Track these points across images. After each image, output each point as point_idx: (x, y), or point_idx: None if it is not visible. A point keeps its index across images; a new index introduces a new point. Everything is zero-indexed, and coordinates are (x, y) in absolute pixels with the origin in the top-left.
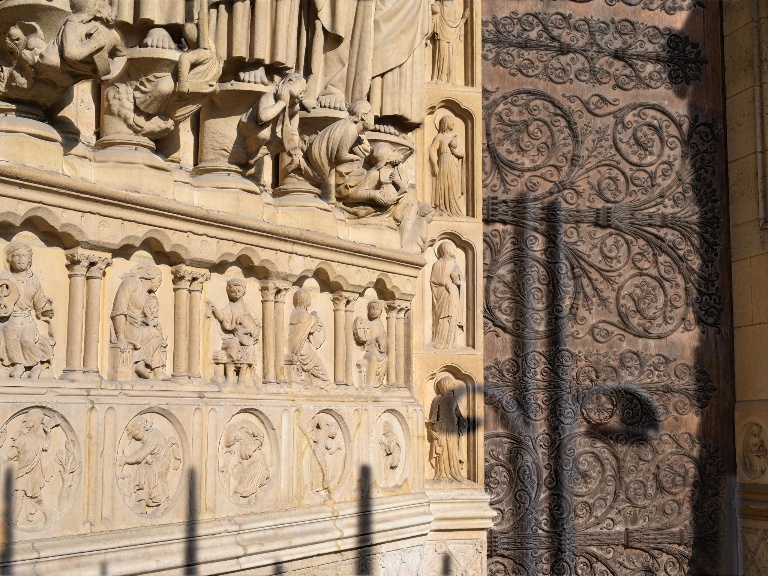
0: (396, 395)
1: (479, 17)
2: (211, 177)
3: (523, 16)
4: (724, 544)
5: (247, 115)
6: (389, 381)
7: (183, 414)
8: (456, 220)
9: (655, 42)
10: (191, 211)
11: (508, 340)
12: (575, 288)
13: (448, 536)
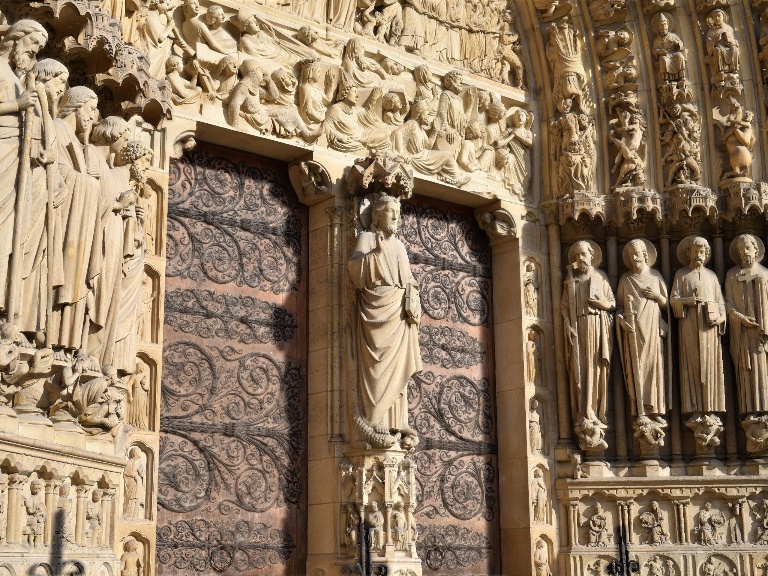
0: (106, 552)
1: (163, 298)
2: (27, 416)
3: (184, 291)
4: None
5: (52, 379)
6: (101, 543)
7: (17, 567)
8: (143, 433)
9: (266, 312)
10: (28, 442)
11: (165, 513)
12: (210, 477)
13: None
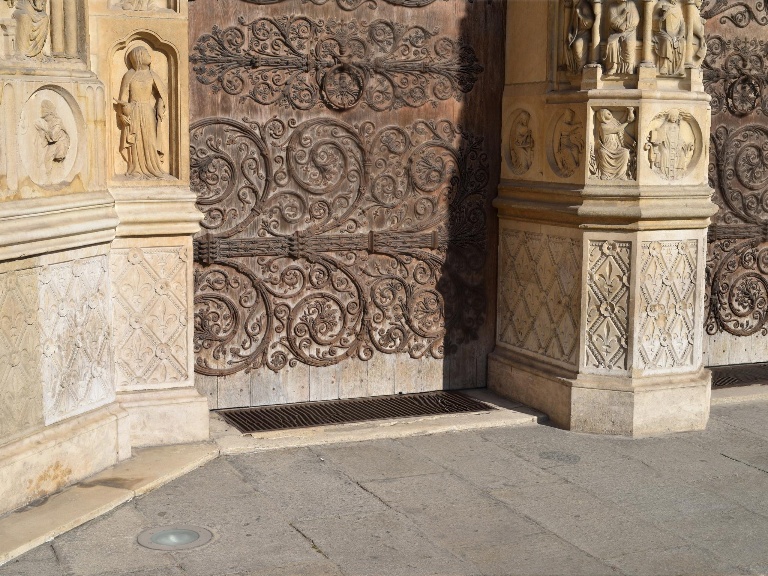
0: (62, 67)
1: None
2: None
3: None
4: (483, 248)
5: None
6: (54, 49)
7: None
8: None
9: None
10: None
11: (230, 4)
12: None
13: (143, 243)
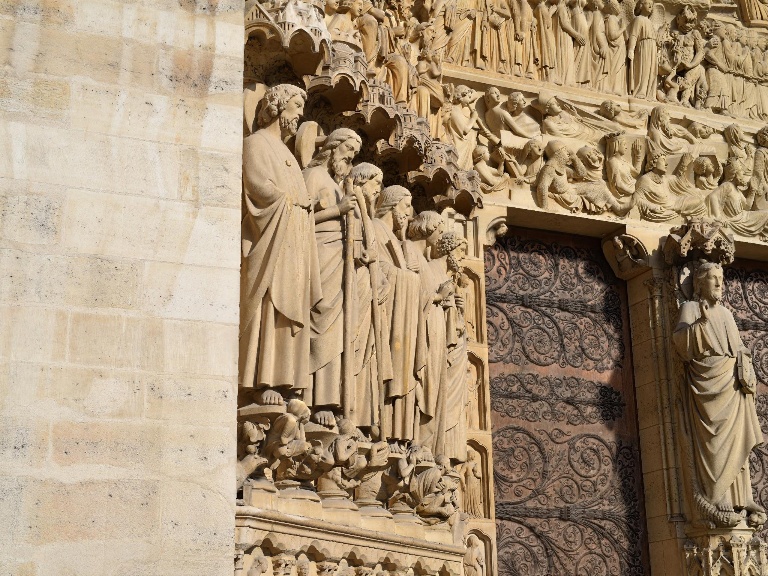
0: None
1: (488, 384)
2: (368, 509)
3: (508, 376)
4: None
5: (388, 471)
6: None
7: None
8: (479, 521)
9: (592, 392)
10: (371, 534)
11: None
12: (549, 564)
13: None
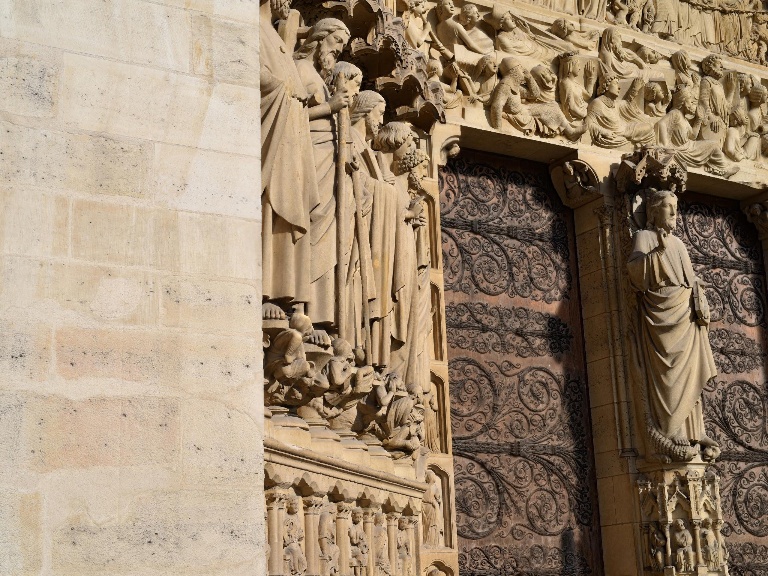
0: None
1: (444, 312)
2: (344, 441)
3: (457, 305)
4: None
5: (365, 399)
6: None
7: None
8: (436, 456)
9: (540, 323)
10: (354, 467)
11: (459, 540)
12: (500, 501)
13: None
